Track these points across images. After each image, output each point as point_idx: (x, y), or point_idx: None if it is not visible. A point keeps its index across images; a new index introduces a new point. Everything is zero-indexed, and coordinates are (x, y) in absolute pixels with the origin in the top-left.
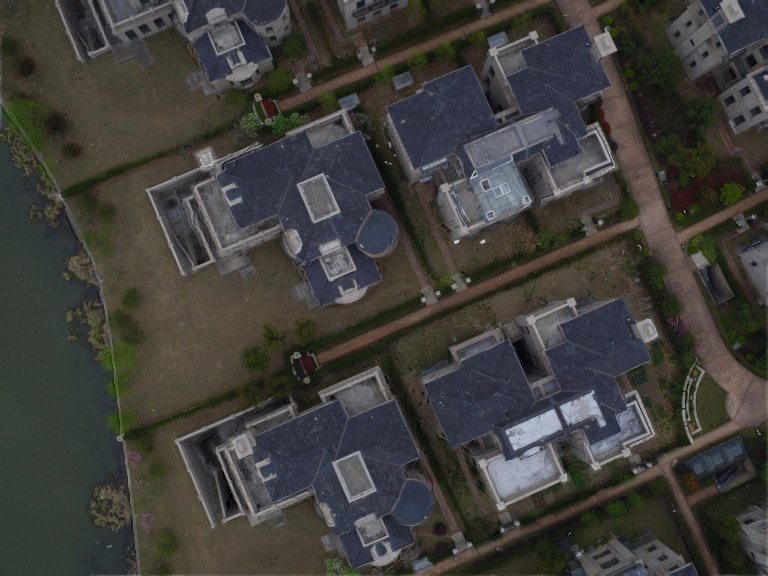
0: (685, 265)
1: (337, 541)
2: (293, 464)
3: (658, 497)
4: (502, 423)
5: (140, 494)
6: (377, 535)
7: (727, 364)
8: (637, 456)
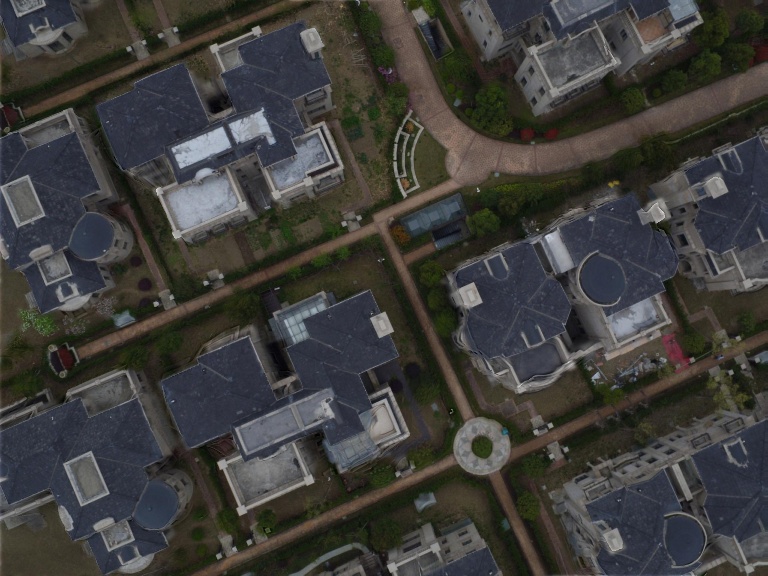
0: (406, 21)
1: None
2: None
3: (368, 250)
4: (171, 143)
5: None
6: (61, 275)
7: (447, 121)
8: (352, 213)
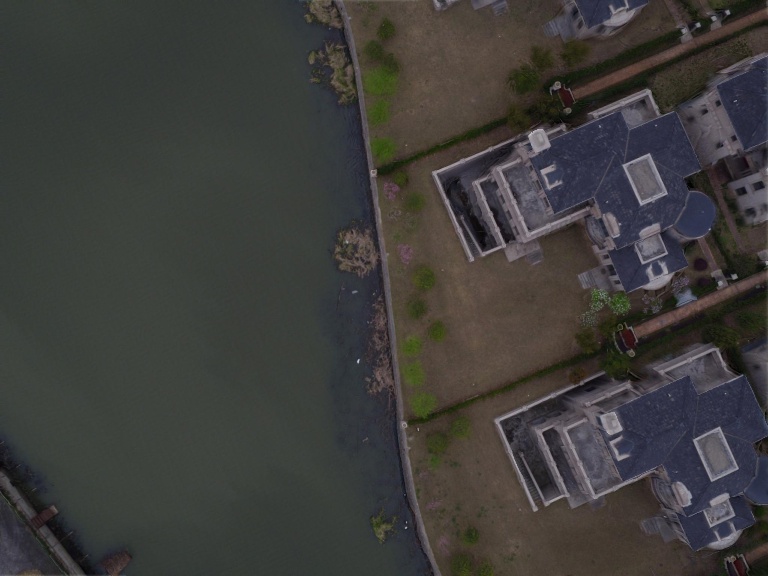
0: None
1: (597, 277)
2: (582, 168)
3: None
4: None
5: (392, 232)
6: (654, 253)
7: None
8: None
